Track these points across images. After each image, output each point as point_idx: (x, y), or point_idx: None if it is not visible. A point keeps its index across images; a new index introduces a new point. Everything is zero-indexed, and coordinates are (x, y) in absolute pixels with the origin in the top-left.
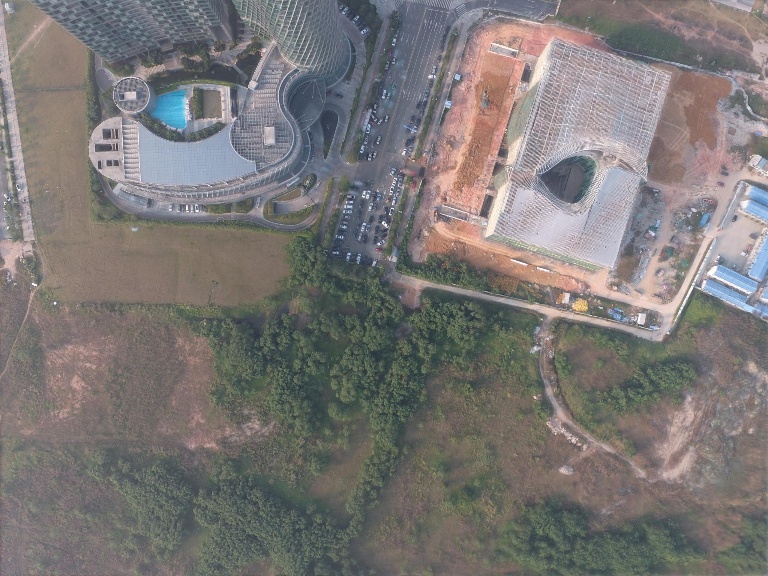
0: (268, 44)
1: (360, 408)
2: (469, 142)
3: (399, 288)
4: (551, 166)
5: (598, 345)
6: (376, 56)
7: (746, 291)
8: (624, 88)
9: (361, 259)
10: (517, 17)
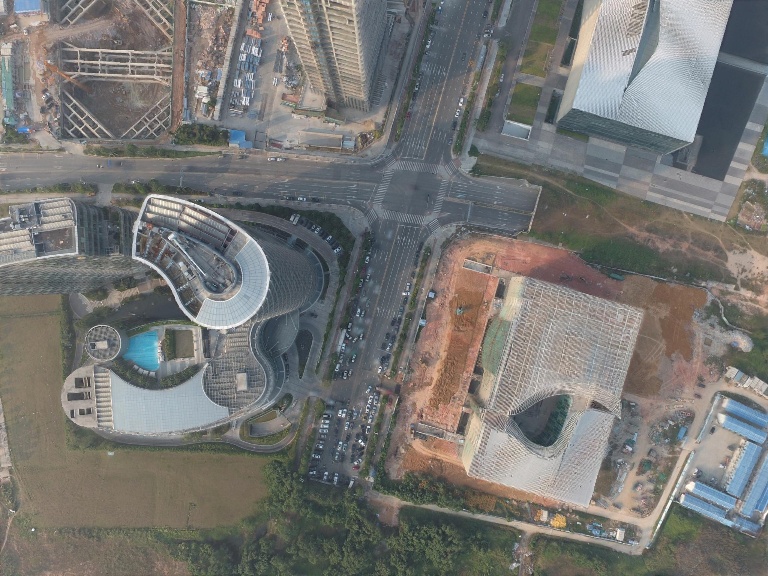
0: None
1: None
2: (444, 358)
3: (377, 506)
4: (524, 409)
5: (577, 563)
6: (350, 274)
7: (725, 506)
8: (596, 328)
9: (338, 479)
10: (490, 232)
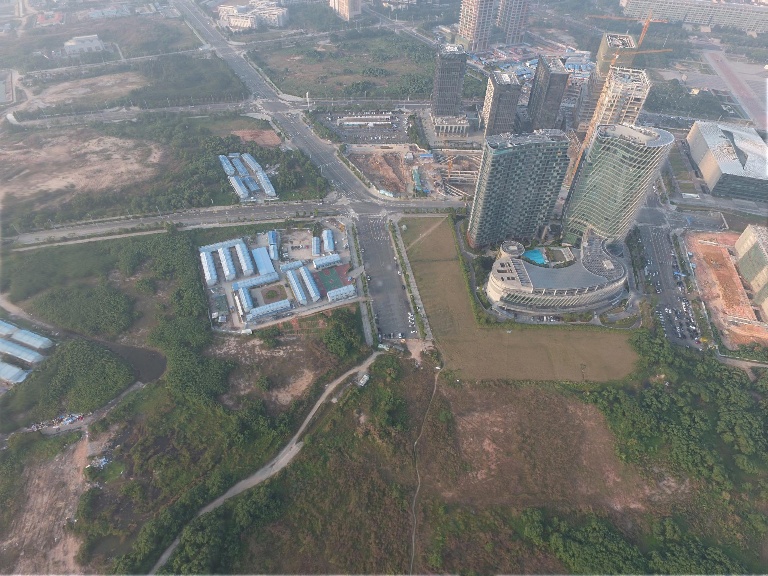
0: (570, 238)
1: (761, 464)
2: (719, 284)
3: None
4: None
5: None
6: None
7: None
8: None
9: None
10: None
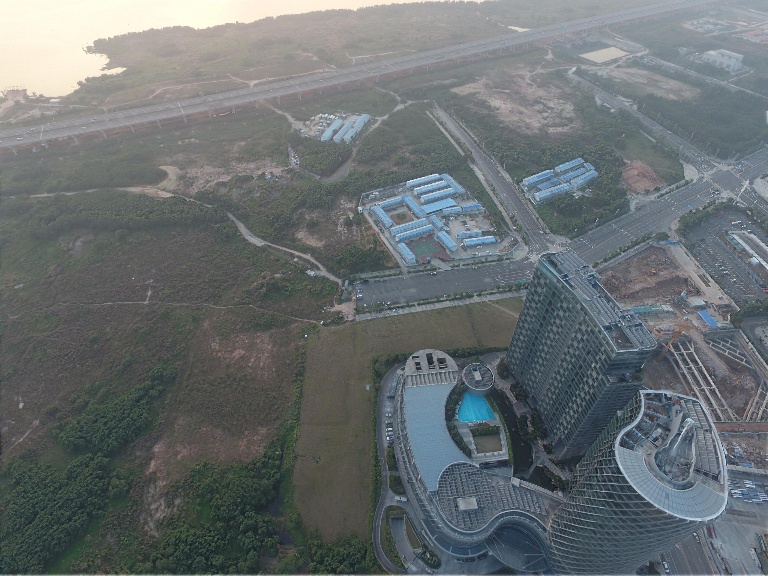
0: None
1: None
2: None
3: None
4: None
5: None
6: None
7: None
8: None
9: None
10: None
